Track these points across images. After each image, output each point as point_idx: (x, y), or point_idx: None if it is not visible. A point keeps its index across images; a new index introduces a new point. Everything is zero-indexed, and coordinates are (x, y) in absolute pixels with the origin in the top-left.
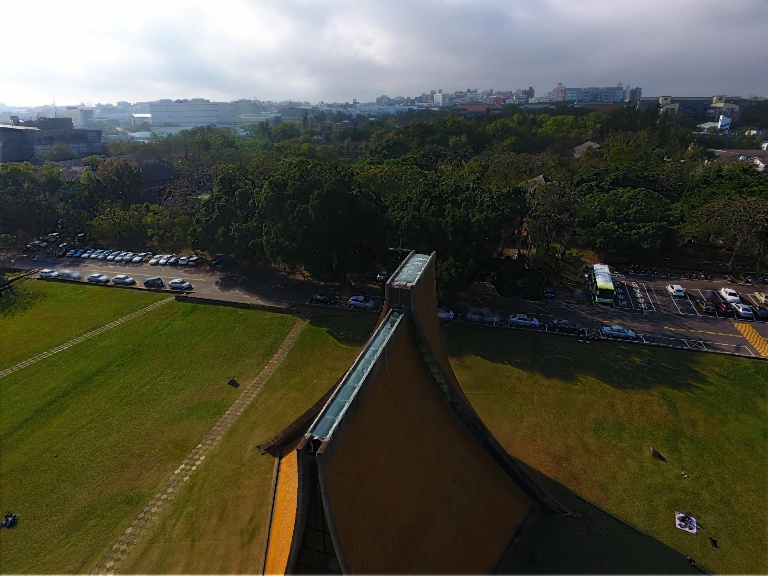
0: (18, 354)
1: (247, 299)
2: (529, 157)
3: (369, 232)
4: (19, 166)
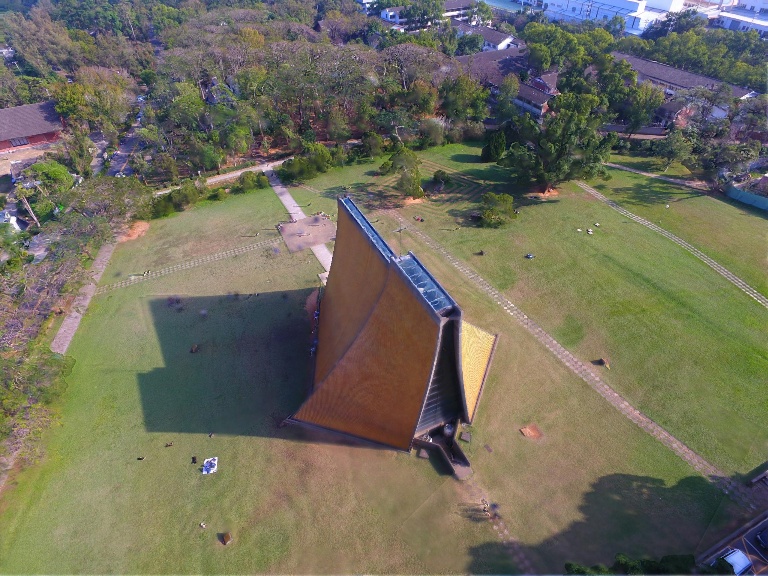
0: (762, 280)
1: None
2: None
3: None
4: None
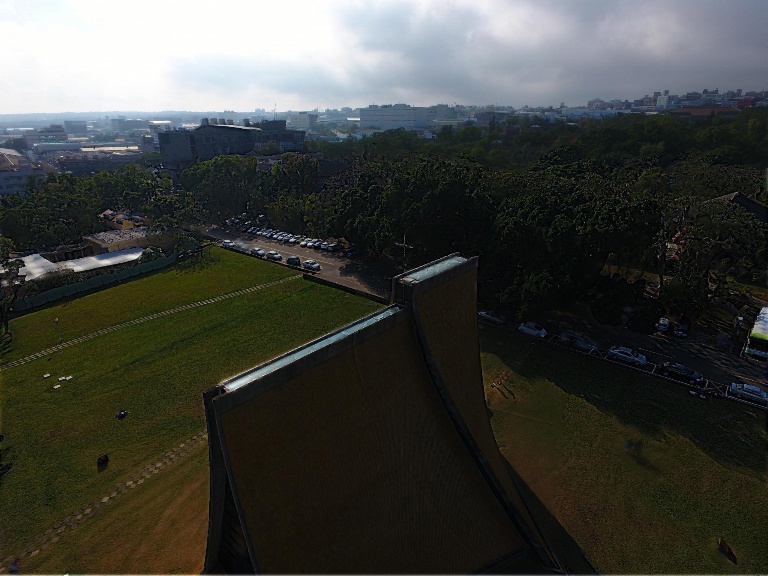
0: (183, 300)
1: (357, 285)
2: (726, 169)
3: (478, 236)
4: (232, 158)
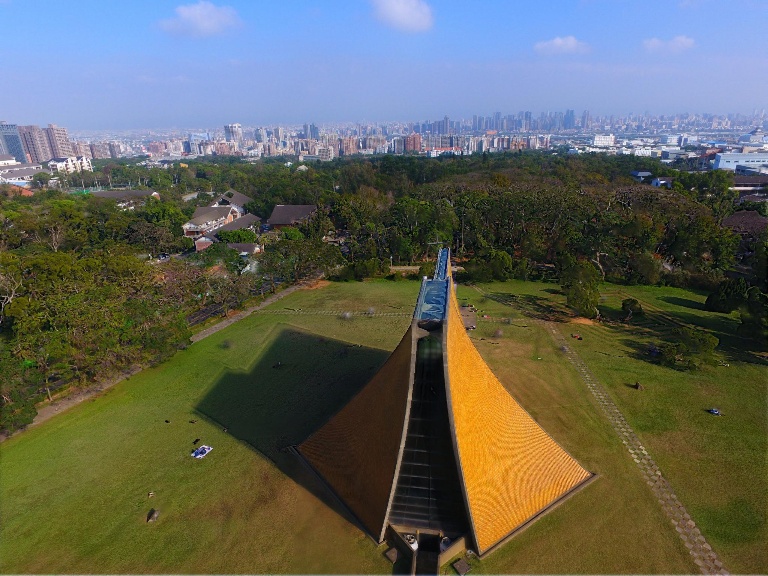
0: None
1: None
2: None
3: None
4: None
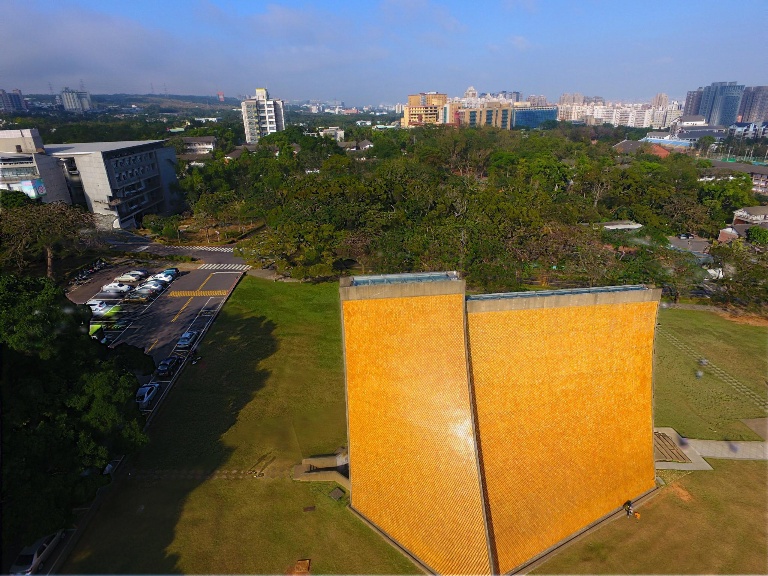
0: None
1: None
2: None
3: None
4: None
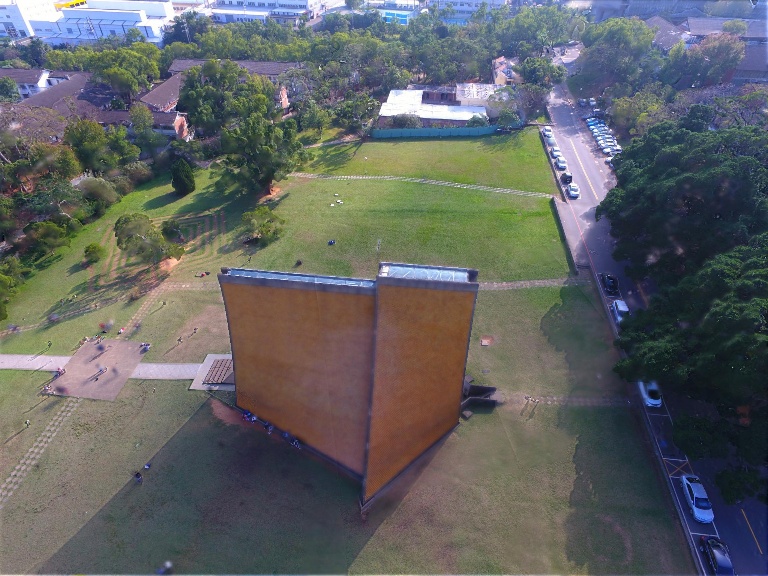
0: (451, 176)
1: (576, 235)
2: None
3: None
4: None
